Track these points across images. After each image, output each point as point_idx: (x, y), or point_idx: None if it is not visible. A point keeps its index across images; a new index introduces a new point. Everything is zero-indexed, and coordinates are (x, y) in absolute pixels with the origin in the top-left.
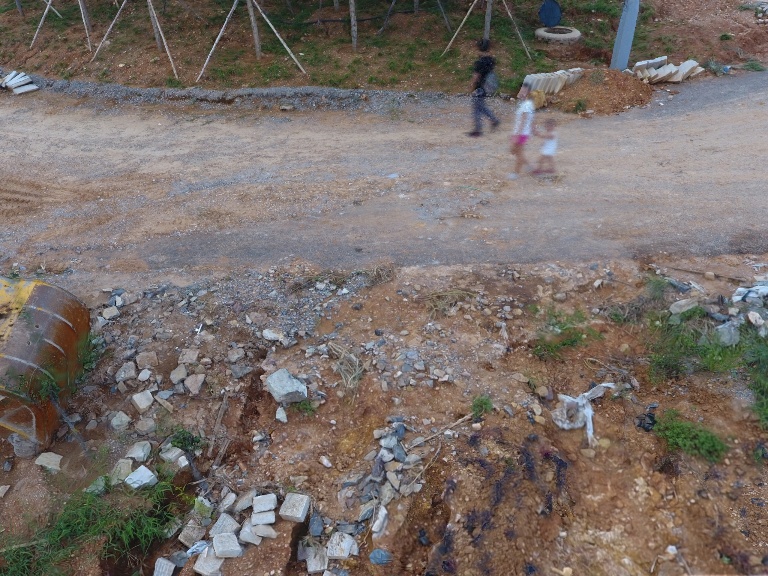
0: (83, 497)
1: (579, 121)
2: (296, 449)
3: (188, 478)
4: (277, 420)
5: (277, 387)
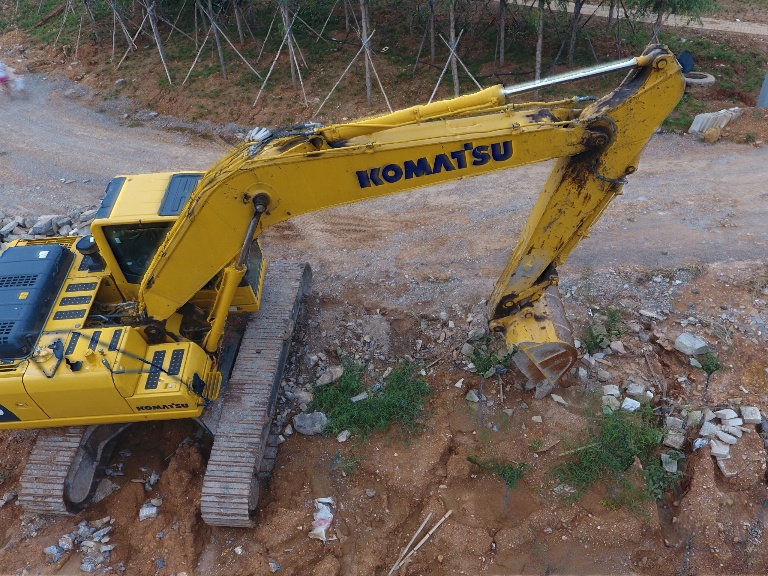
0: None
1: (754, 150)
2: (718, 383)
3: None
4: (693, 367)
5: (690, 344)
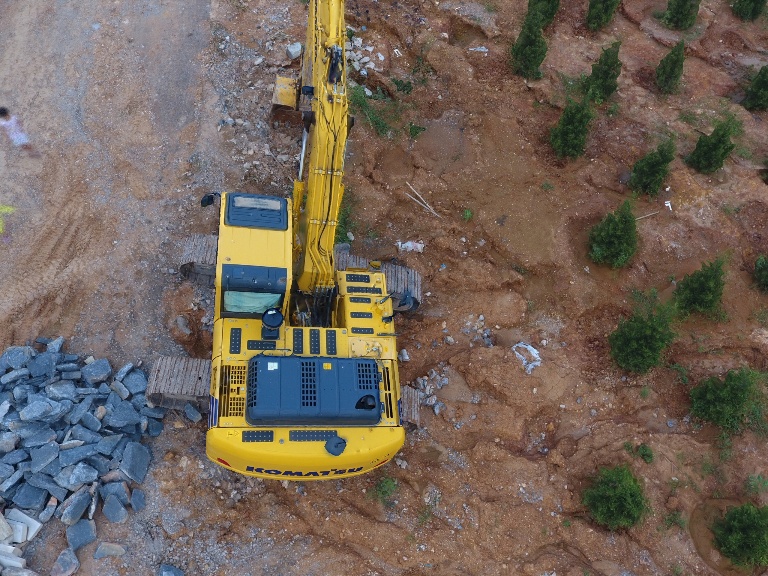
0: None
1: None
2: None
3: None
4: None
5: (298, 49)
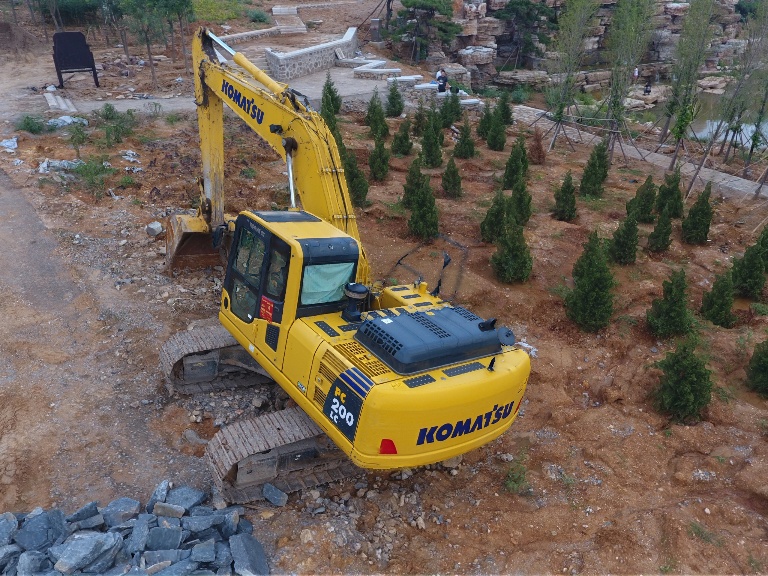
0: None
1: None
2: None
3: None
4: None
5: (159, 225)
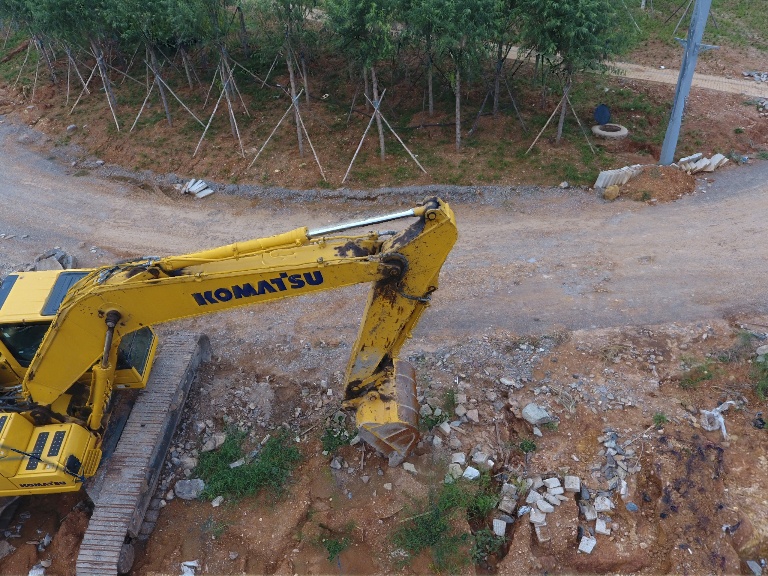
0: (447, 486)
1: (648, 208)
2: (554, 452)
3: (491, 473)
4: (535, 435)
5: (533, 415)
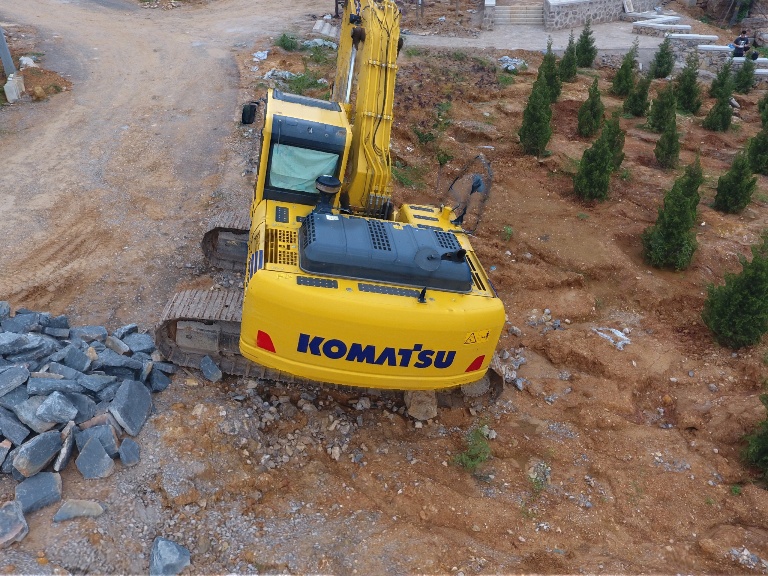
0: None
1: (75, 92)
2: None
3: None
4: None
5: None
